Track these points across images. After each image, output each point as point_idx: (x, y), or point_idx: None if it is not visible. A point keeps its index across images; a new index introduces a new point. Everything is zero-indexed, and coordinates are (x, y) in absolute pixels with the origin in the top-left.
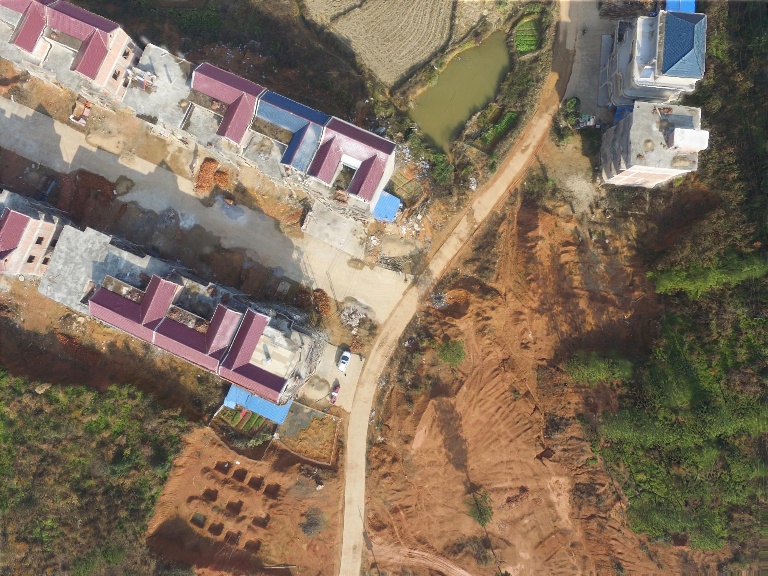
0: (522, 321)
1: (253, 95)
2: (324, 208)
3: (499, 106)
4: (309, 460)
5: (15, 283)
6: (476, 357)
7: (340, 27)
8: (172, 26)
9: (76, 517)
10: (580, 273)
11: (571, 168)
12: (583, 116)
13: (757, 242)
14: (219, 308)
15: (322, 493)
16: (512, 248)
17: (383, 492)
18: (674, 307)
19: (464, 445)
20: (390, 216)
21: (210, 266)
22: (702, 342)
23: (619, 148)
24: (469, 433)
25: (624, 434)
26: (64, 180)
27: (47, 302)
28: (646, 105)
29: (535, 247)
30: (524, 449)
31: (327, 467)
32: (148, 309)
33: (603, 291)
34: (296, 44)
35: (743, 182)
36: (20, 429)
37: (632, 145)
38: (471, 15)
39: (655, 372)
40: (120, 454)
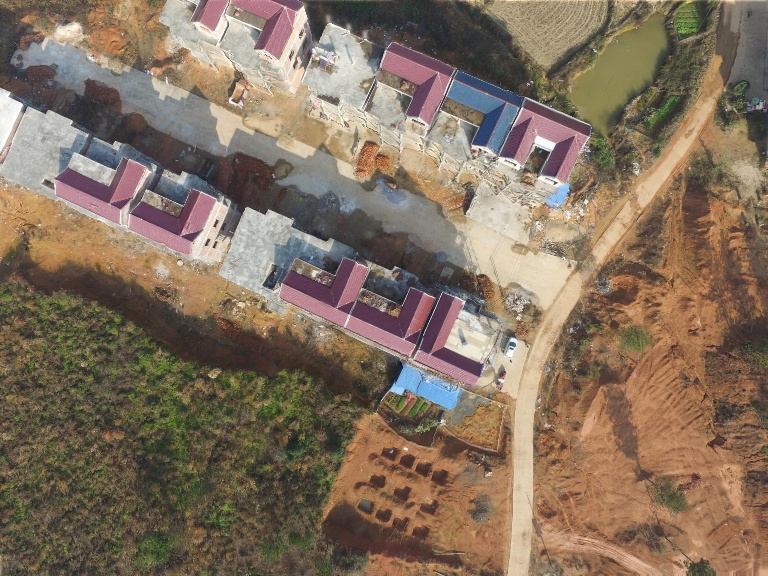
0: (691, 307)
1: (447, 75)
2: (488, 193)
3: (660, 90)
4: (476, 447)
5: (173, 268)
6: (645, 344)
7: (495, 9)
8: (326, 7)
9: (254, 502)
10: (748, 259)
11: (737, 153)
12: (753, 100)
13: None
14: (412, 292)
15: (491, 480)
16: (679, 234)
17: (552, 479)
18: None
19: (634, 432)
20: (560, 201)
21: (372, 251)
22: None
23: None
24: (639, 420)
25: None
26: (222, 163)
27: (206, 287)
28: None
29: (707, 232)
30: (696, 436)
31: (494, 454)
32: (343, 292)
33: None
34: (453, 26)
35: None
36: (193, 414)
37: None
38: None
39: None
40: (295, 439)
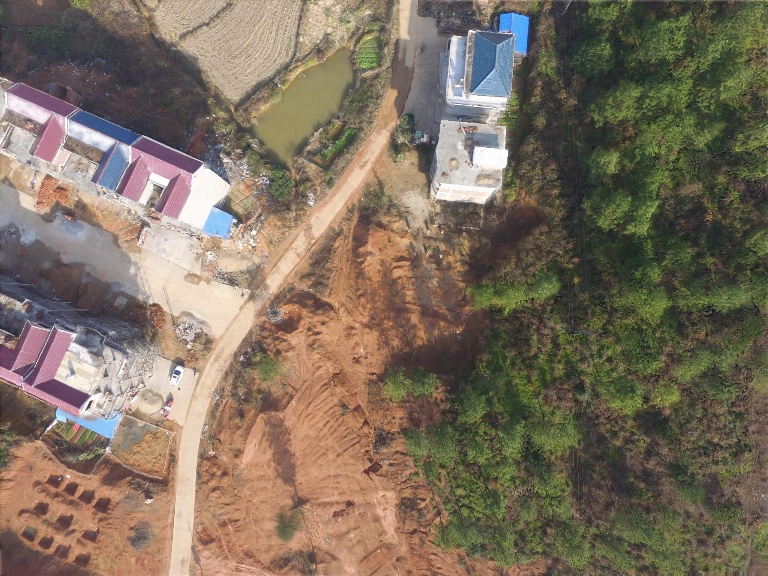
0: (353, 336)
1: (62, 115)
2: None
3: (341, 122)
4: (141, 474)
5: None
6: (306, 372)
7: (188, 45)
8: (22, 44)
9: None
10: (413, 288)
11: (407, 184)
12: (416, 133)
13: (575, 258)
14: (27, 324)
15: (152, 507)
16: (346, 263)
17: (212, 506)
18: (497, 322)
19: (292, 459)
20: (221, 232)
21: (49, 281)
22: (522, 357)
23: (435, 165)
24: (297, 447)
25: (446, 449)
26: None
27: None
28: (452, 124)
29: (364, 262)
30: (351, 463)
31: (158, 481)
32: None
33: (435, 306)
34: (142, 62)
35: (563, 198)
36: None
37: (437, 163)
38: (315, 33)
39: (477, 387)
40: None
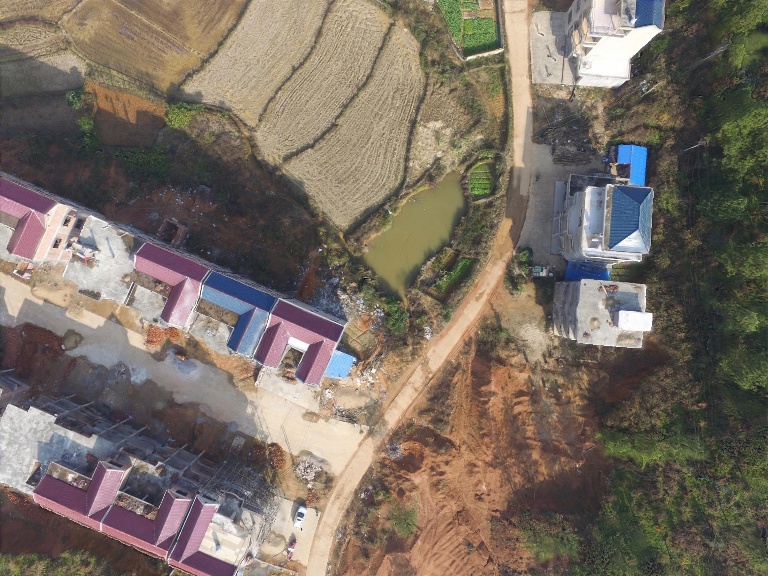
0: (476, 474)
1: (197, 280)
2: None
3: (454, 251)
4: None
5: None
6: (431, 511)
7: (293, 168)
8: (119, 169)
9: None
10: (533, 423)
11: (525, 316)
12: (536, 268)
13: (702, 403)
14: (167, 495)
15: None
16: (466, 399)
17: None
18: (623, 463)
19: None
20: (343, 374)
21: (163, 422)
22: (649, 499)
23: (568, 315)
24: None
25: None
26: (10, 335)
27: None
28: (592, 282)
29: (488, 403)
30: None
31: None
32: (94, 500)
33: (555, 441)
34: (247, 188)
35: (690, 342)
36: None
37: (579, 323)
38: (425, 157)
39: (604, 528)
40: None
